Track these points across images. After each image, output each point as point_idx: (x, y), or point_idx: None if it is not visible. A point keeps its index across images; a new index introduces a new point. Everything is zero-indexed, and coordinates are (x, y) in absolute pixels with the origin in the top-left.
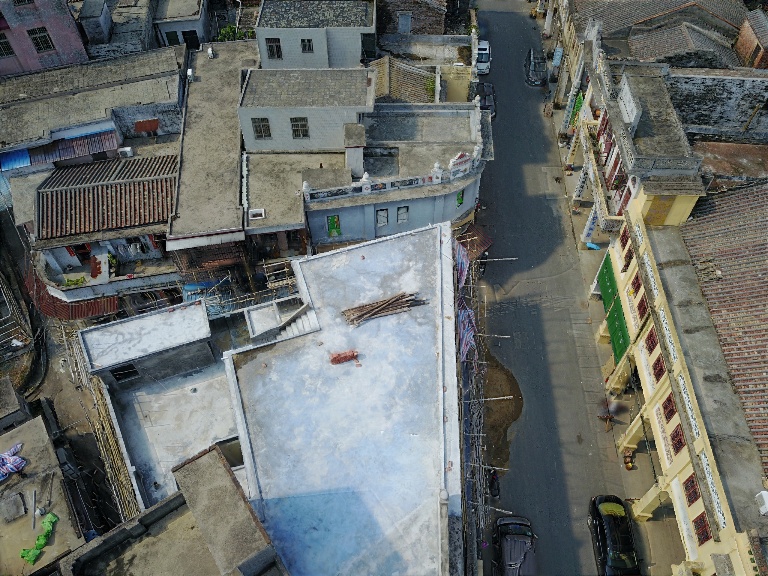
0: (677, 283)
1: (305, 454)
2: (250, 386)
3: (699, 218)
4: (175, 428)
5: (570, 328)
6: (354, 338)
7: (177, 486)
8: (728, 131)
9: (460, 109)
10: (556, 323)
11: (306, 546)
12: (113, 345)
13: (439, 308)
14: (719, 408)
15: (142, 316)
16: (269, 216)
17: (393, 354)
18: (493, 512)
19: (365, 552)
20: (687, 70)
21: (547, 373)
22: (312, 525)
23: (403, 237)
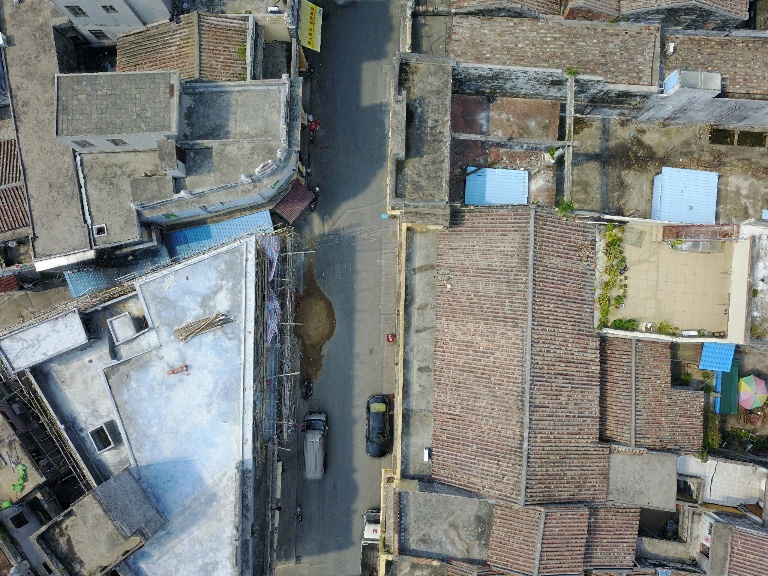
0: (422, 288)
1: (159, 437)
2: (119, 392)
3: (451, 229)
4: (84, 389)
5: (380, 258)
6: (184, 352)
7: (92, 438)
8: (494, 140)
9: (271, 85)
10: (370, 253)
11: (165, 491)
12: (22, 350)
13: (243, 325)
14: (421, 391)
15: (35, 326)
16: (110, 231)
17: (211, 364)
18: (308, 405)
19: (198, 493)
20: (496, 23)
21: (356, 300)
22: (168, 479)
23: (217, 255)
